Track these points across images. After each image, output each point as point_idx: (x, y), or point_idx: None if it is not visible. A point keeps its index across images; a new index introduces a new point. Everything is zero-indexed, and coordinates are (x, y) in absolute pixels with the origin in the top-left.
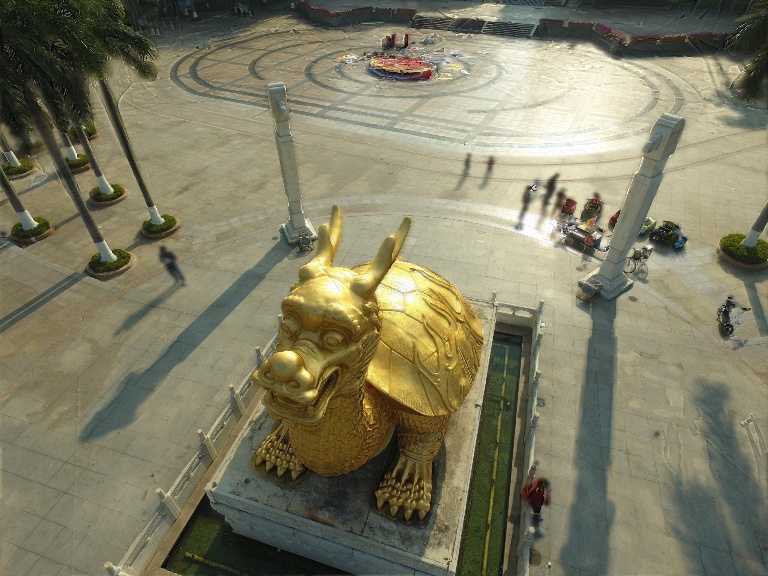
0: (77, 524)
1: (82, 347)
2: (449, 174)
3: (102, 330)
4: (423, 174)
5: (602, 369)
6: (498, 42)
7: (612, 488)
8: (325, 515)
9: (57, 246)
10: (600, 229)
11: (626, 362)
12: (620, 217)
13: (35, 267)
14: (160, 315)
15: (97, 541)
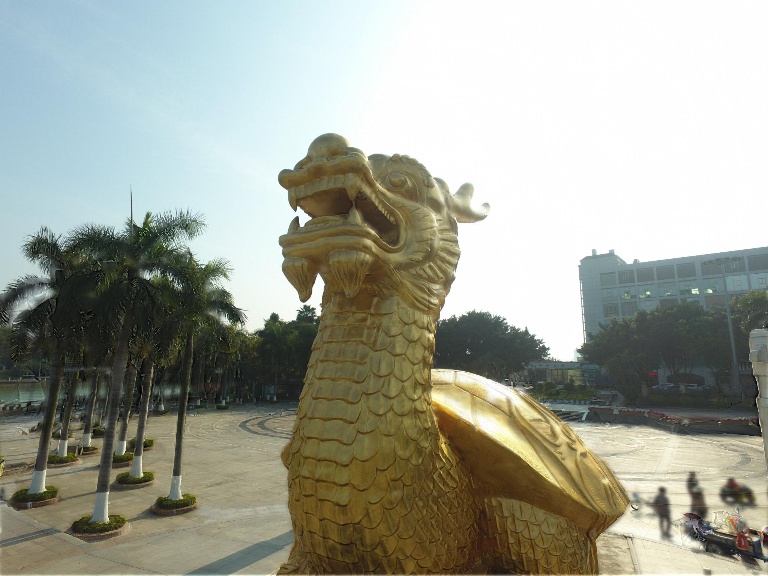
0: None
1: None
2: None
3: None
4: None
5: None
6: None
7: None
8: None
9: (50, 513)
10: (751, 530)
11: None
12: (767, 462)
13: (11, 520)
14: (125, 572)
15: None
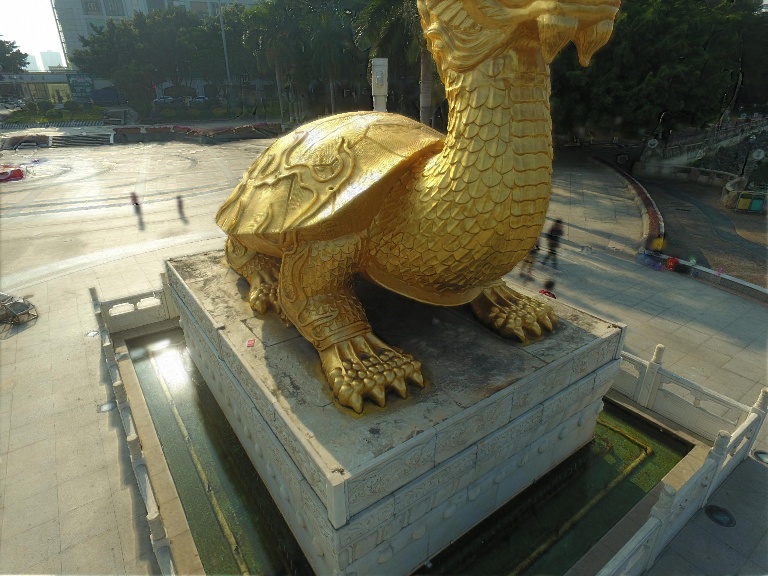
0: None
1: None
2: (149, 223)
3: None
4: (115, 231)
5: None
6: (80, 150)
7: None
8: (500, 379)
9: None
10: None
11: None
12: None
13: None
14: None
15: None
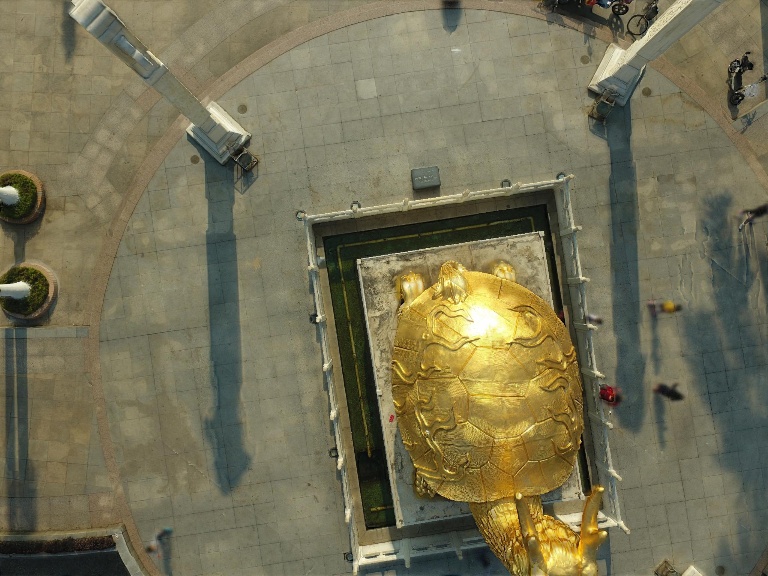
0: (287, 537)
1: (130, 414)
2: None
3: (127, 387)
4: None
5: (625, 216)
6: None
7: (644, 337)
8: None
9: None
10: None
11: (646, 196)
12: (664, 30)
13: None
14: (168, 343)
15: (311, 539)
